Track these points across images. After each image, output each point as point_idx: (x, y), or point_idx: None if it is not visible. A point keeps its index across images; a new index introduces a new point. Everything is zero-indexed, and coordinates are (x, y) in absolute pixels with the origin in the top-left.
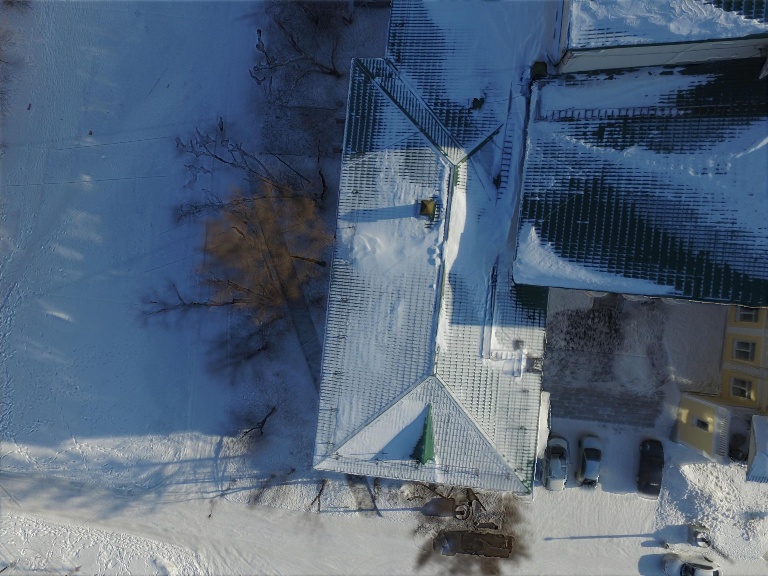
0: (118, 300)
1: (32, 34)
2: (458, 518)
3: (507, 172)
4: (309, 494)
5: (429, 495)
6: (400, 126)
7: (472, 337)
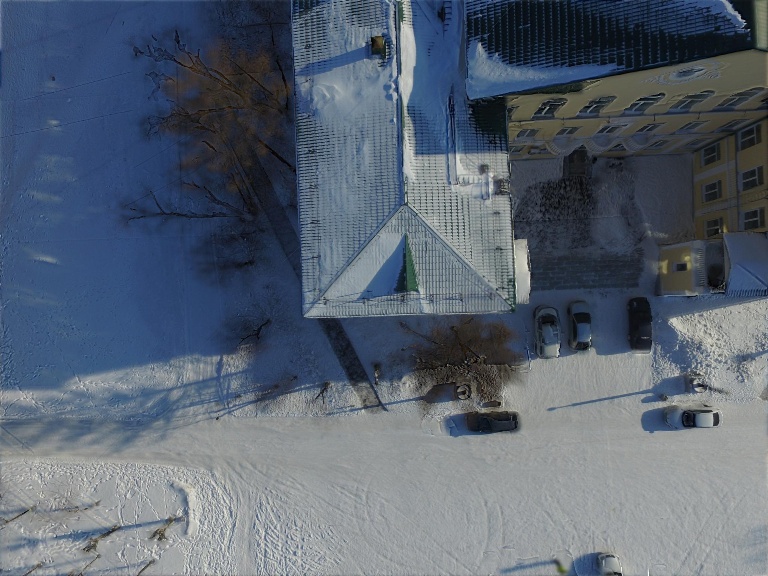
0: (102, 237)
1: None
2: (461, 398)
3: (450, 3)
4: (314, 399)
5: (430, 383)
6: None
7: (438, 165)
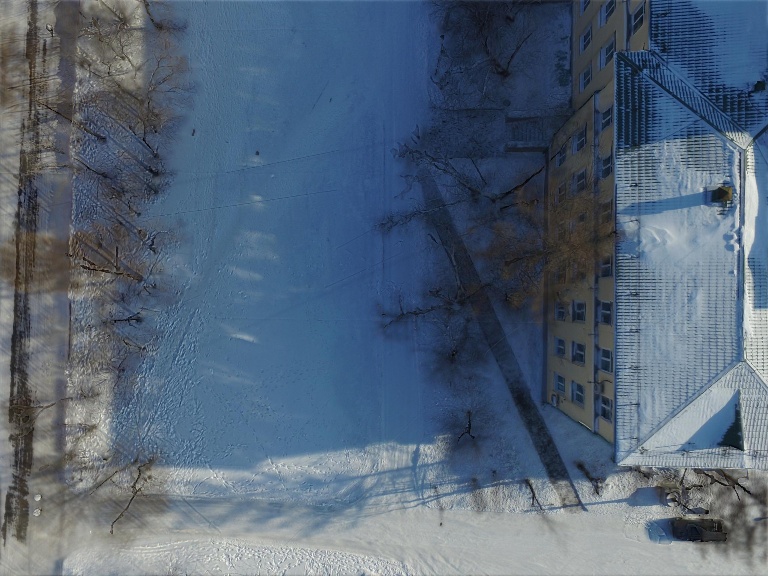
0: (301, 317)
1: (189, 60)
2: (670, 506)
3: None
4: (512, 495)
5: (634, 485)
6: (677, 116)
7: None
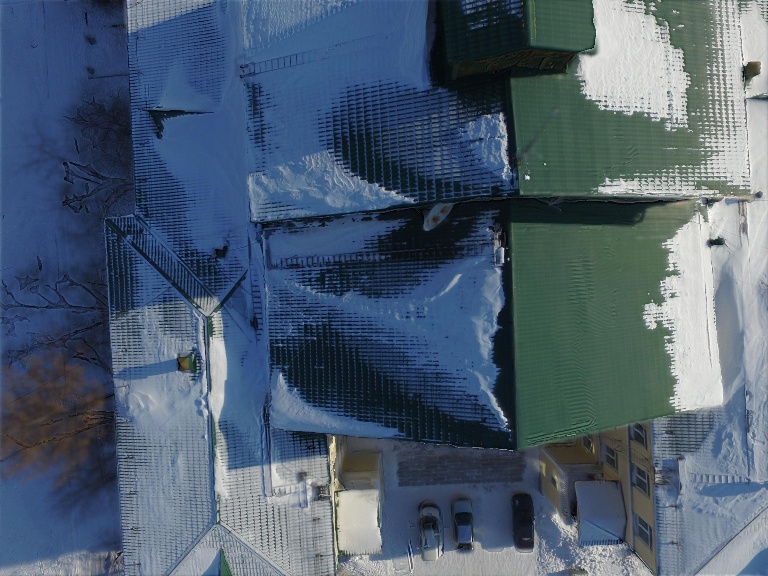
0: None
1: None
2: None
3: (261, 314)
4: None
5: None
6: (155, 282)
7: (252, 478)
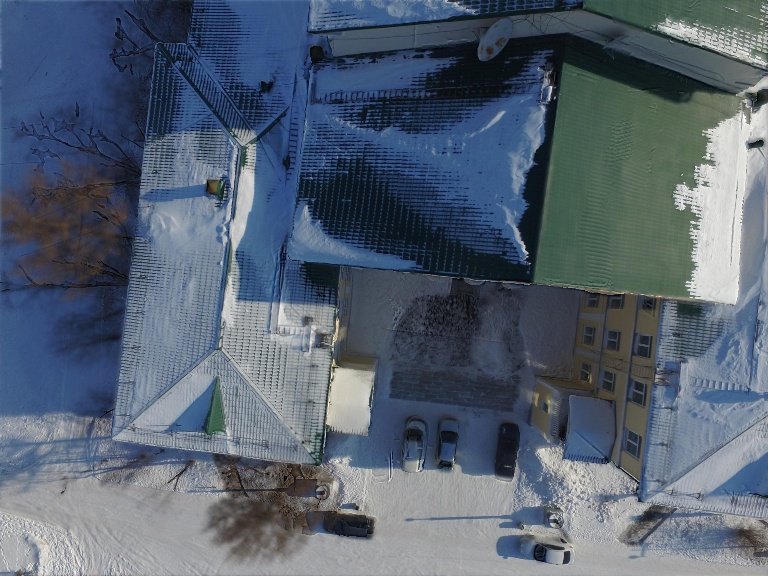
0: None
1: None
2: (318, 498)
3: (294, 153)
4: None
5: None
6: (196, 108)
7: (260, 313)
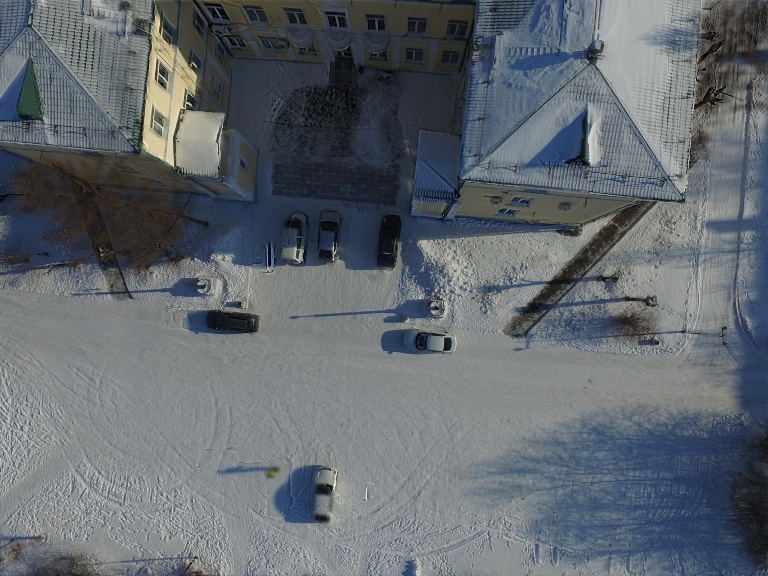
0: None
1: None
2: (199, 292)
3: None
4: (62, 278)
5: (177, 275)
6: None
7: None
